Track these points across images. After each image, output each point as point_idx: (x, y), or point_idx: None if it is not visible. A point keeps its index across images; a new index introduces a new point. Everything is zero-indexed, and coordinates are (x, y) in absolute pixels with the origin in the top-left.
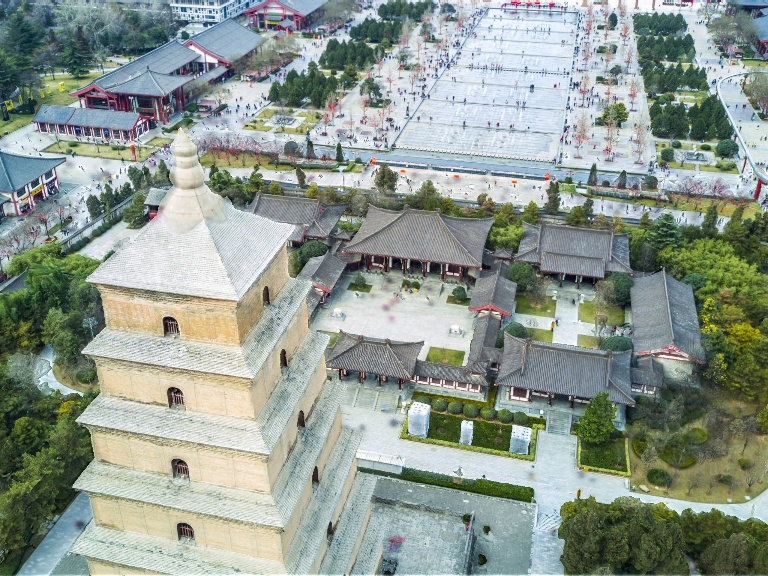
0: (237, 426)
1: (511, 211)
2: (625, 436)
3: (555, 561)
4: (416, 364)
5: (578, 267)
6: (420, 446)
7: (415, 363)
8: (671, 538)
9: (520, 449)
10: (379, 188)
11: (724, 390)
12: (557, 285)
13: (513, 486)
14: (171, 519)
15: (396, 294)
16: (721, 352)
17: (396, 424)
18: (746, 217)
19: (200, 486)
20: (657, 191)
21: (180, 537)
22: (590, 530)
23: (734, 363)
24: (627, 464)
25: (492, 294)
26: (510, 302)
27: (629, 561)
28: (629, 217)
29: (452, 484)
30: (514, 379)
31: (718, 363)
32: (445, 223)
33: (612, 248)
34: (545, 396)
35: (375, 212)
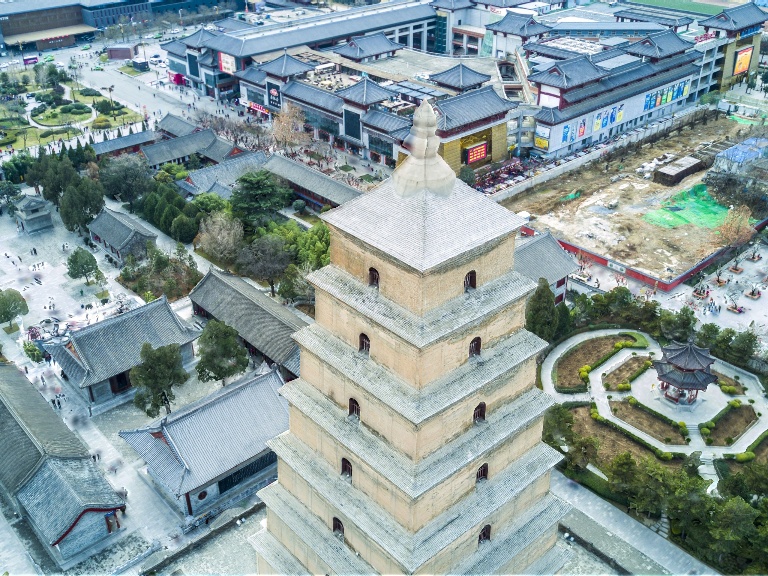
0: None
1: None
2: None
3: None
4: None
5: None
6: None
7: None
8: None
9: None
10: None
11: None
12: None
13: None
14: None
15: None
16: None
17: None
18: None
19: None
20: None
21: None
22: None
23: None
24: None
25: None
26: None
27: None
28: None
29: None
30: None
31: None
32: None
33: None
34: None
35: None
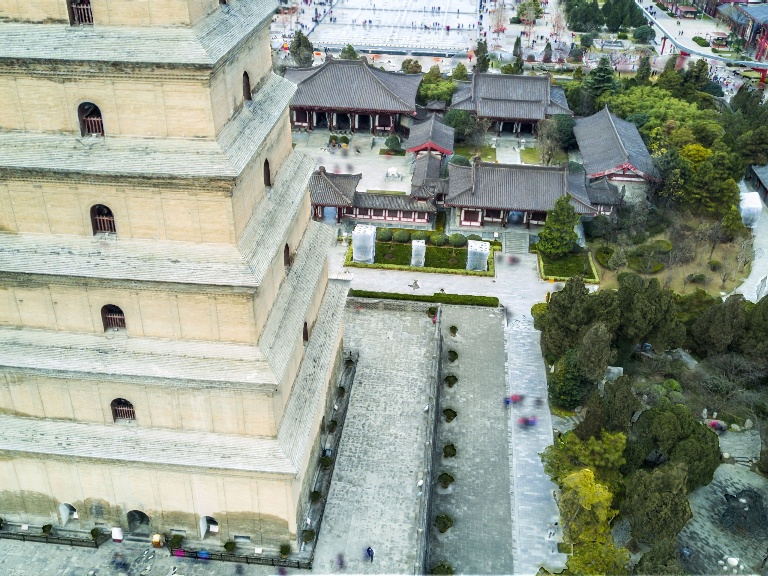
0: (166, 37)
1: (439, 74)
2: (587, 250)
3: (533, 354)
4: (355, 195)
5: (517, 111)
6: (367, 271)
7: (354, 193)
8: (665, 297)
9: (478, 265)
10: (295, 58)
11: (683, 205)
12: (495, 135)
13: (475, 297)
14: (81, 201)
15: (323, 149)
16: (676, 169)
17: (338, 255)
18: (679, 67)
19: (119, 142)
20: (583, 63)
21: (95, 232)
22: (576, 296)
23: (691, 177)
24: (594, 273)
25: (430, 132)
26: (450, 142)
27: (620, 330)
28: (560, 77)
29: (409, 296)
30: (465, 199)
31: (675, 179)
32: (372, 73)
33: (550, 93)
34: (498, 220)
35: (293, 73)
